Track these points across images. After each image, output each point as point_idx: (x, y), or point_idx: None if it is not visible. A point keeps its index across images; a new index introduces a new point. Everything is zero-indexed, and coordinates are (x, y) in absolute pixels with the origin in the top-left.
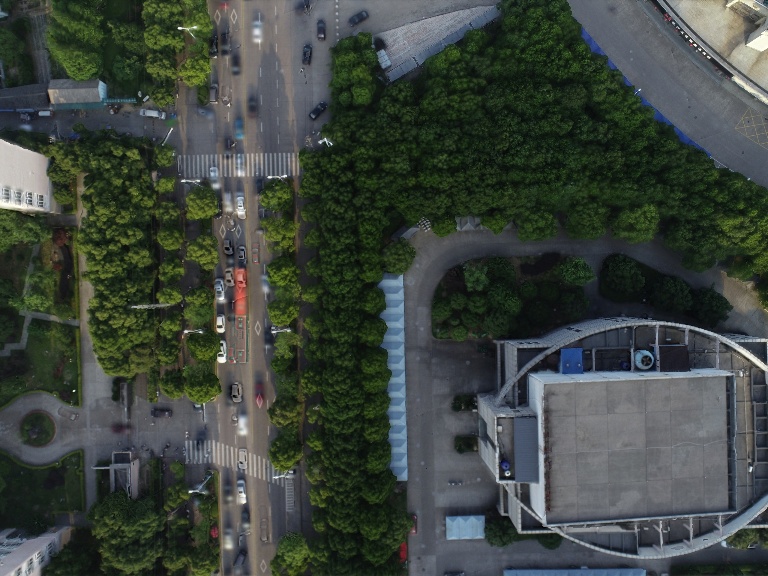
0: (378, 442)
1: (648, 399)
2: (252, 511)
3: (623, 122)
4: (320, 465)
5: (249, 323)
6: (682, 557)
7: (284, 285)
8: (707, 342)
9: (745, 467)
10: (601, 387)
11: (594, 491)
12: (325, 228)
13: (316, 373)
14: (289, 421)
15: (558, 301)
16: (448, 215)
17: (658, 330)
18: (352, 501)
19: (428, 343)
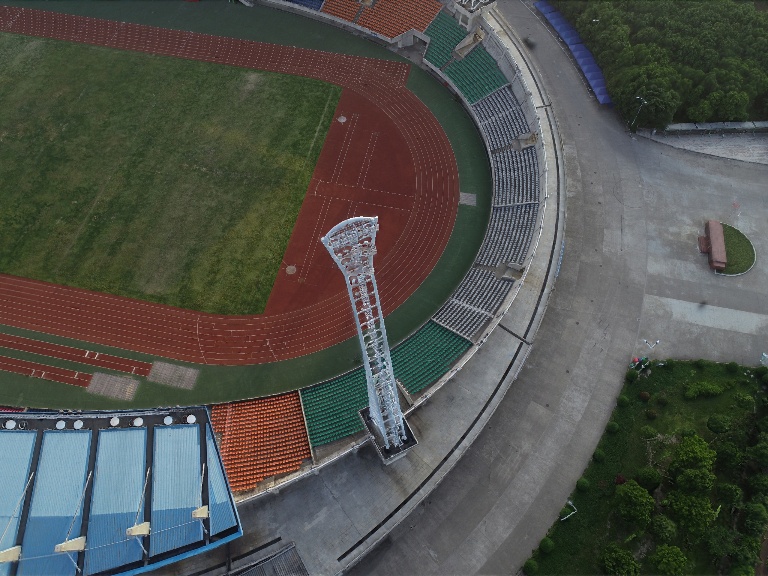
0: None
1: None
2: None
3: None
4: None
5: None
6: None
7: None
8: None
9: None
10: None
11: None
12: None
13: None
14: None
15: None
16: None
17: None
18: None
19: None
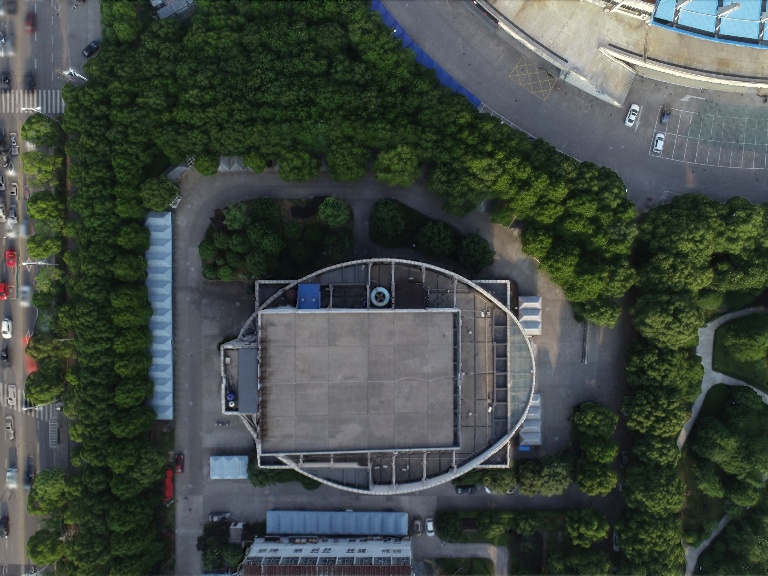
0: (130, 377)
1: (371, 333)
2: (20, 447)
3: (379, 63)
4: (75, 399)
5: (20, 259)
6: (447, 502)
7: (42, 219)
8: (450, 282)
9: (485, 407)
10: (322, 319)
11: (313, 422)
12: (80, 162)
13: (72, 307)
14: (43, 354)
15: (322, 243)
16: (206, 152)
17: (395, 267)
18: (100, 434)
19: (198, 284)
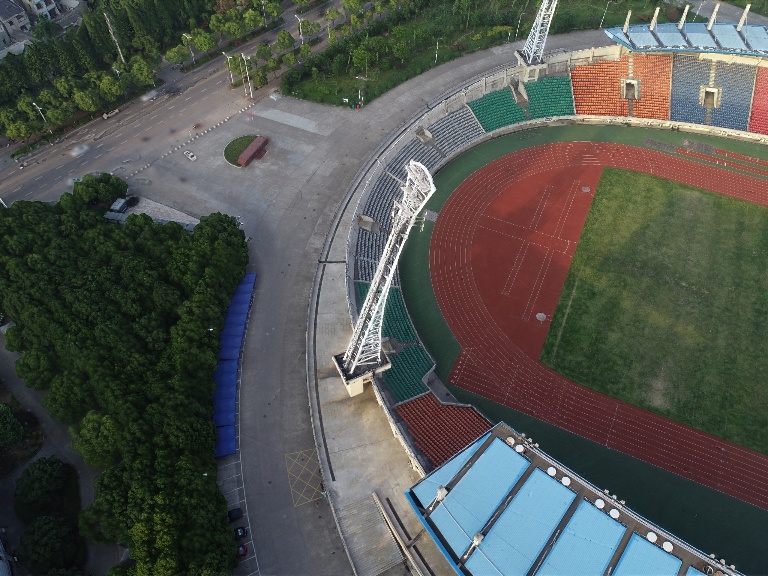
0: None
1: None
2: None
3: None
4: None
5: None
6: None
7: None
8: None
9: None
10: None
11: None
12: None
13: None
14: None
15: None
16: None
17: None
18: None
19: None
